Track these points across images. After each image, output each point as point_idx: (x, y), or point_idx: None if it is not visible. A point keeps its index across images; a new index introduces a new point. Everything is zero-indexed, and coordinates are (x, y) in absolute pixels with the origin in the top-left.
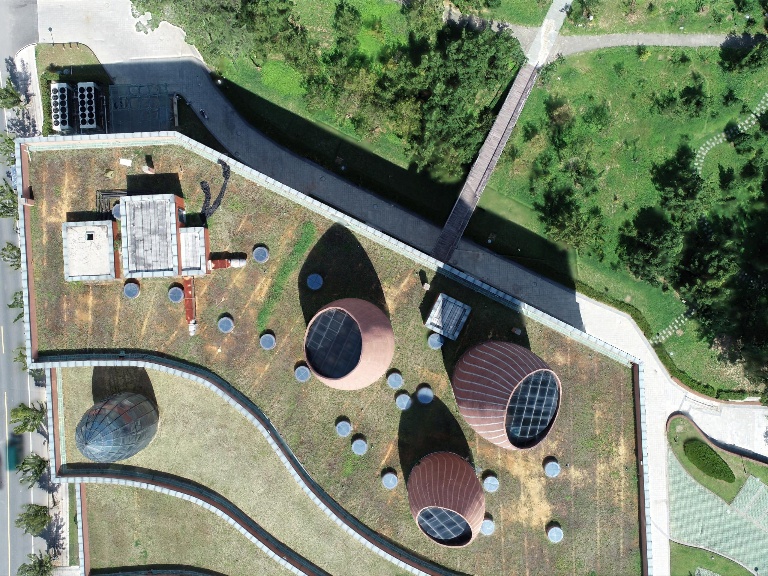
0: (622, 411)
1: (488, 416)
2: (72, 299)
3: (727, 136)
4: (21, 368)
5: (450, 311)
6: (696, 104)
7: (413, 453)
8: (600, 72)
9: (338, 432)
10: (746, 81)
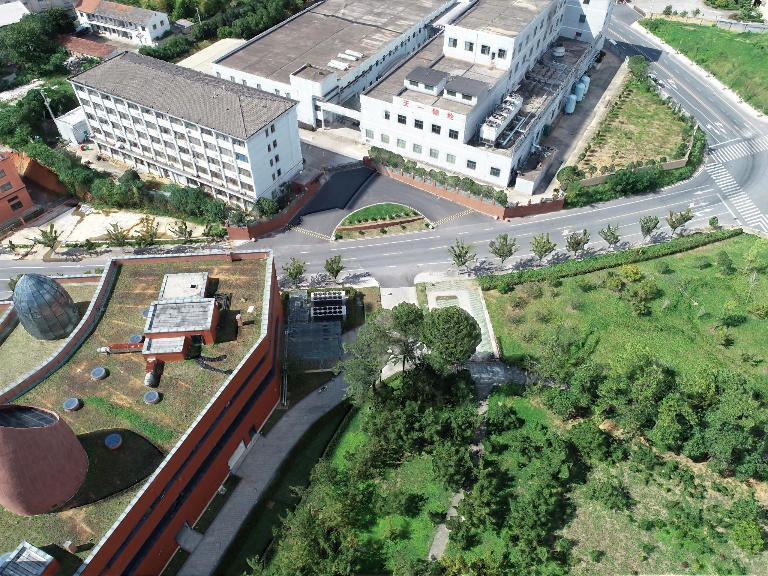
0: None
1: None
2: (155, 282)
3: None
4: None
5: (30, 571)
6: None
7: None
8: None
9: None
10: None
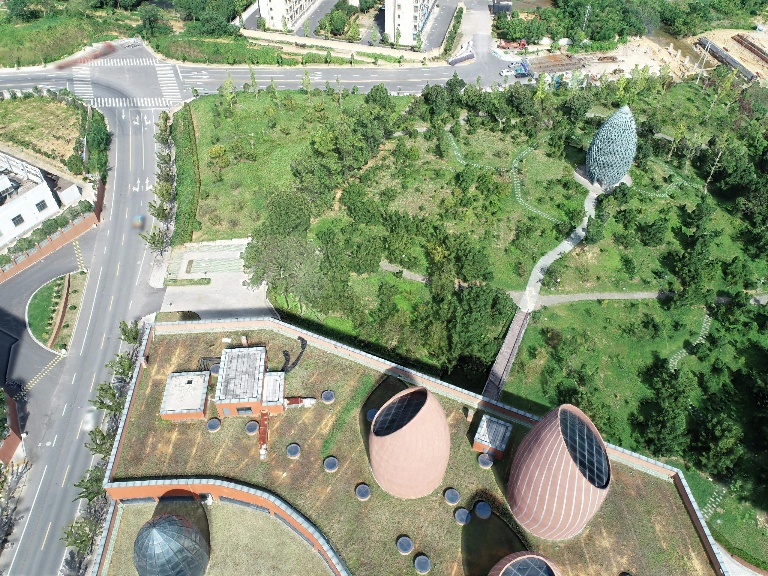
0: (681, 524)
1: (545, 439)
2: (158, 435)
3: (687, 351)
4: (54, 565)
5: (494, 430)
6: (653, 327)
7: (479, 573)
8: (575, 315)
9: (399, 548)
10: (684, 316)
